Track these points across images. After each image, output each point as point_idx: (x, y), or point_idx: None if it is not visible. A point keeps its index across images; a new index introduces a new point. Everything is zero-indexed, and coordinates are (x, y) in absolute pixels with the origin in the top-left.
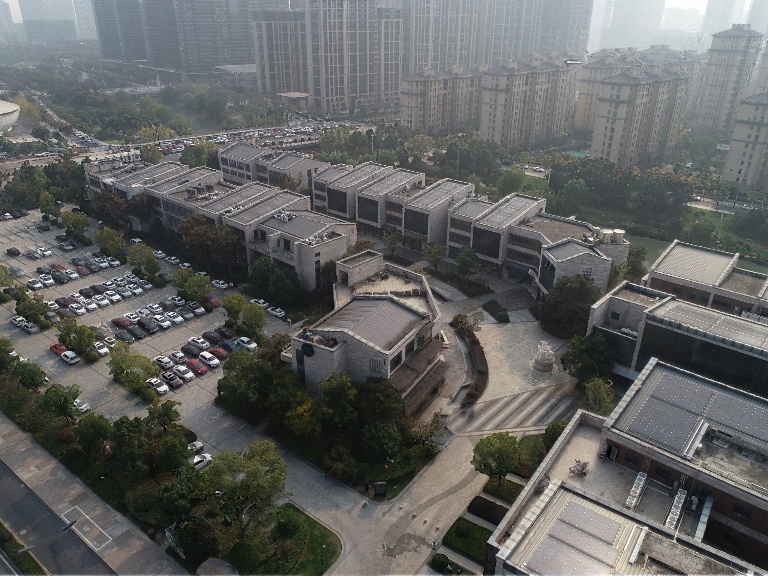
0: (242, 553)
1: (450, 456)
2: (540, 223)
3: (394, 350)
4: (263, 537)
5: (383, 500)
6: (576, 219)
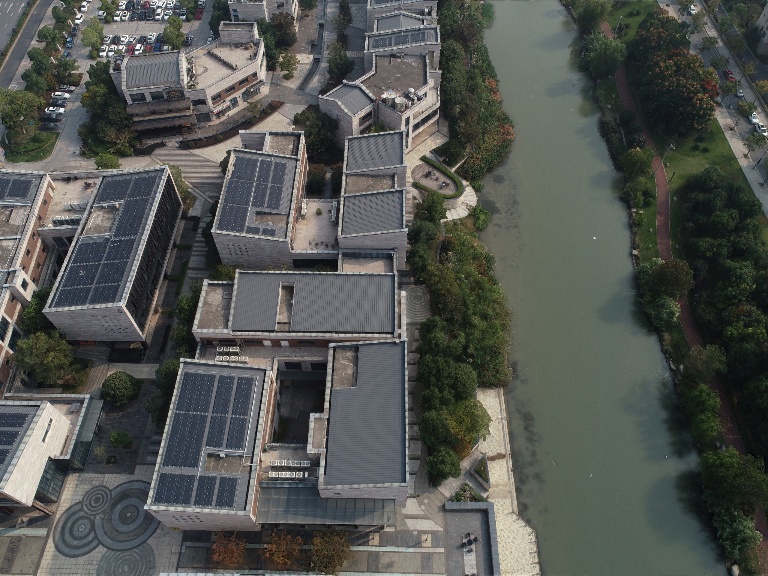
0: (7, 133)
1: (131, 161)
2: (405, 63)
3: (132, 89)
4: (29, 136)
5: (82, 156)
6: (593, 85)
